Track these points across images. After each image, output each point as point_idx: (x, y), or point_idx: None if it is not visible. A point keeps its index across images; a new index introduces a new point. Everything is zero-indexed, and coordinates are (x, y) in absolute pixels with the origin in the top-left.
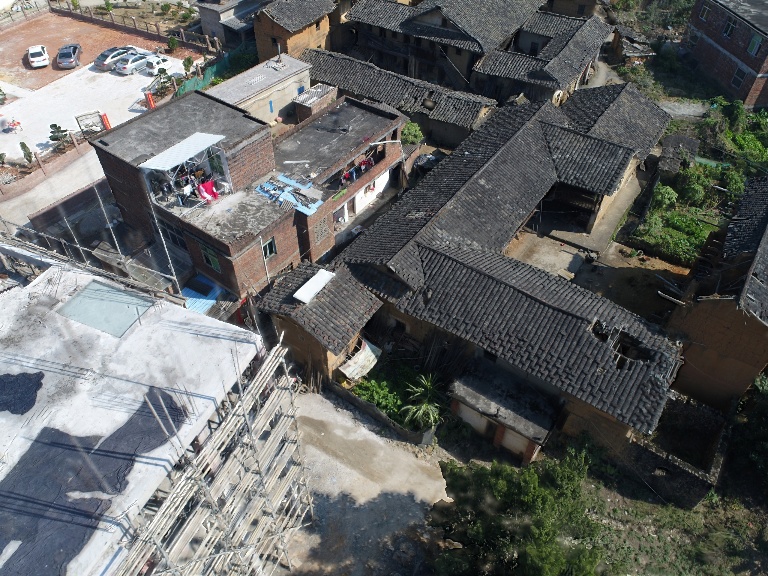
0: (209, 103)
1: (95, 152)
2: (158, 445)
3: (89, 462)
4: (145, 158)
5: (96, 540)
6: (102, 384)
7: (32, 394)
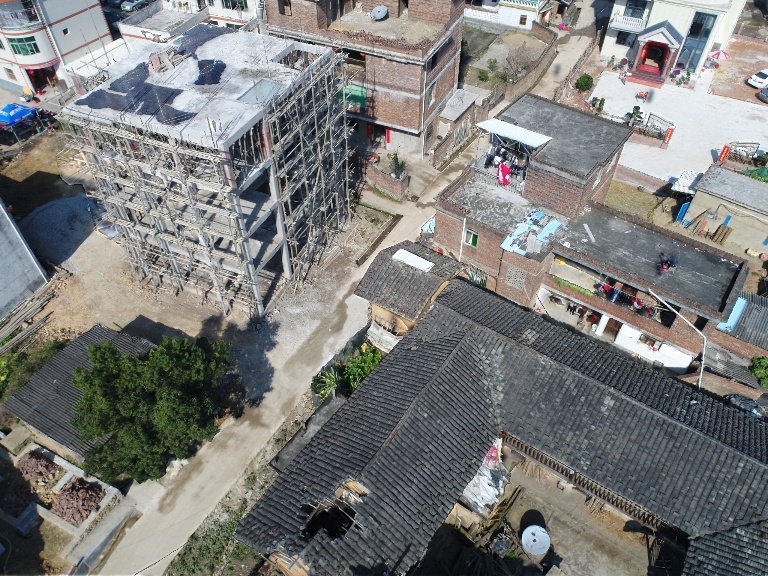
0: (614, 141)
1: (634, 146)
2: (158, 120)
3: (158, 104)
4: (509, 121)
5: (116, 112)
6: (205, 100)
7: (206, 83)
